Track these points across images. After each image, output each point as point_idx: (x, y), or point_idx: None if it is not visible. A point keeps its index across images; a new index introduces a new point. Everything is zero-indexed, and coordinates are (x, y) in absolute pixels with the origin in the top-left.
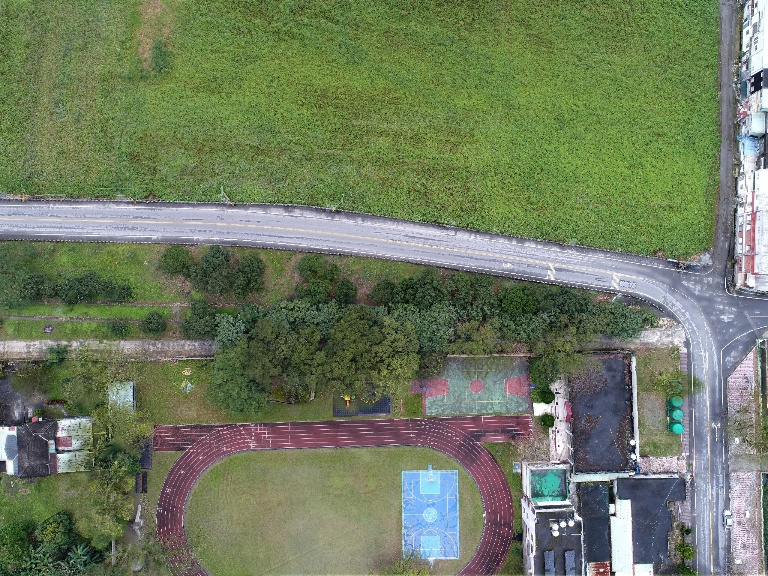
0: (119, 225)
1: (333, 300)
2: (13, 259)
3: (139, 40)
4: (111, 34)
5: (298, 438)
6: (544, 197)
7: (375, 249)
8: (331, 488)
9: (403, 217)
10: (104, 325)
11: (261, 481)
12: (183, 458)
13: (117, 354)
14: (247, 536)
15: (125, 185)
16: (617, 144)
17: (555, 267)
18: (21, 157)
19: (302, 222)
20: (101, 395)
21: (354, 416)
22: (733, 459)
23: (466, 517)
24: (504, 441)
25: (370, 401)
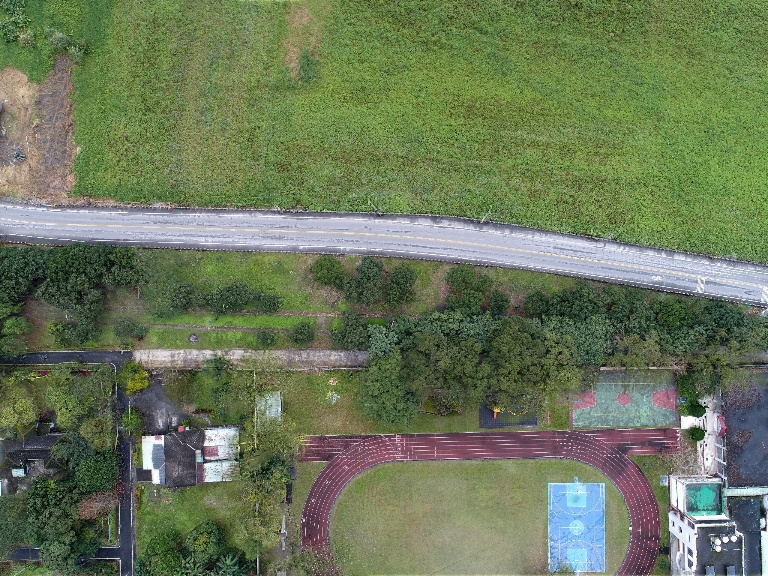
0: (265, 234)
1: (487, 312)
2: (164, 268)
3: None
4: (258, 42)
5: (444, 449)
6: (694, 210)
7: (523, 261)
8: (477, 500)
9: (552, 229)
10: (249, 334)
11: (406, 492)
12: (328, 468)
13: (262, 363)
14: (392, 547)
15: (272, 194)
16: (767, 157)
17: (704, 280)
18: (167, 165)
19: (450, 233)
20: (246, 404)
21: (500, 428)
22: None
23: (612, 530)
24: (651, 454)
25: (517, 413)
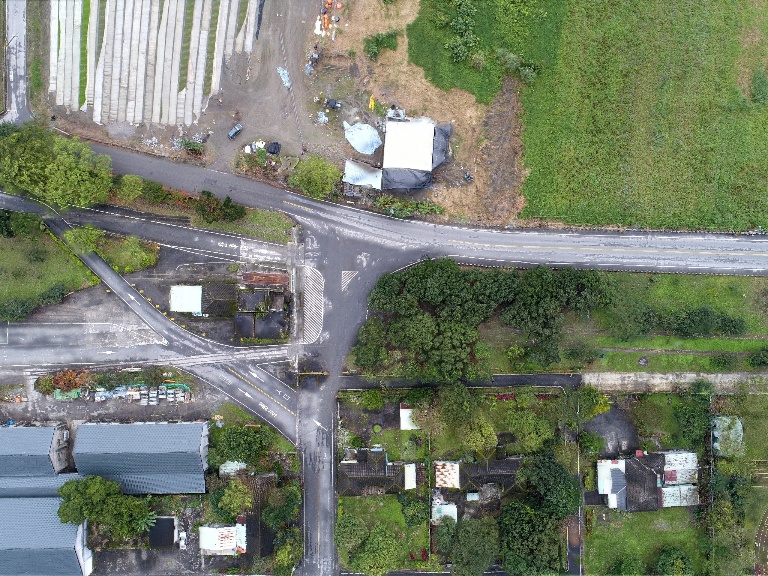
0: (719, 257)
1: None
2: None
3: (738, 70)
4: (710, 63)
5: None
6: None
7: None
8: None
9: None
10: (700, 358)
11: None
12: None
13: (715, 387)
14: None
15: (726, 217)
16: None
17: None
18: (618, 187)
19: None
20: None
21: None
22: None
23: None
24: None
25: None
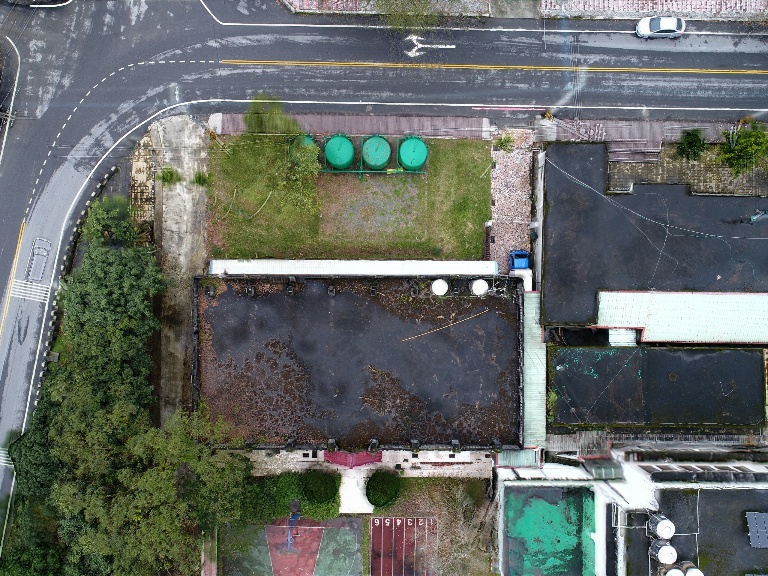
0: None
1: None
2: None
3: None
4: None
5: None
6: None
7: None
8: None
9: None
10: None
11: None
12: None
13: None
14: None
15: None
16: None
17: None
18: None
19: None
20: None
21: None
22: (503, 6)
23: None
24: None
25: None
